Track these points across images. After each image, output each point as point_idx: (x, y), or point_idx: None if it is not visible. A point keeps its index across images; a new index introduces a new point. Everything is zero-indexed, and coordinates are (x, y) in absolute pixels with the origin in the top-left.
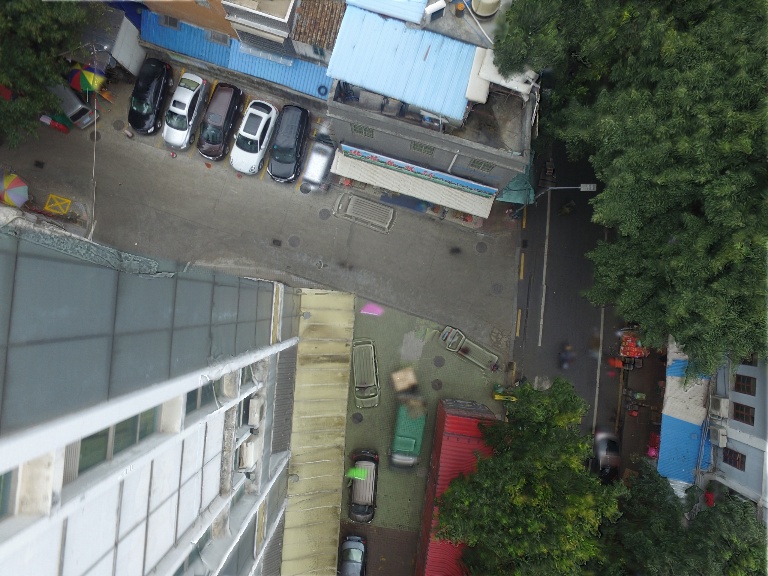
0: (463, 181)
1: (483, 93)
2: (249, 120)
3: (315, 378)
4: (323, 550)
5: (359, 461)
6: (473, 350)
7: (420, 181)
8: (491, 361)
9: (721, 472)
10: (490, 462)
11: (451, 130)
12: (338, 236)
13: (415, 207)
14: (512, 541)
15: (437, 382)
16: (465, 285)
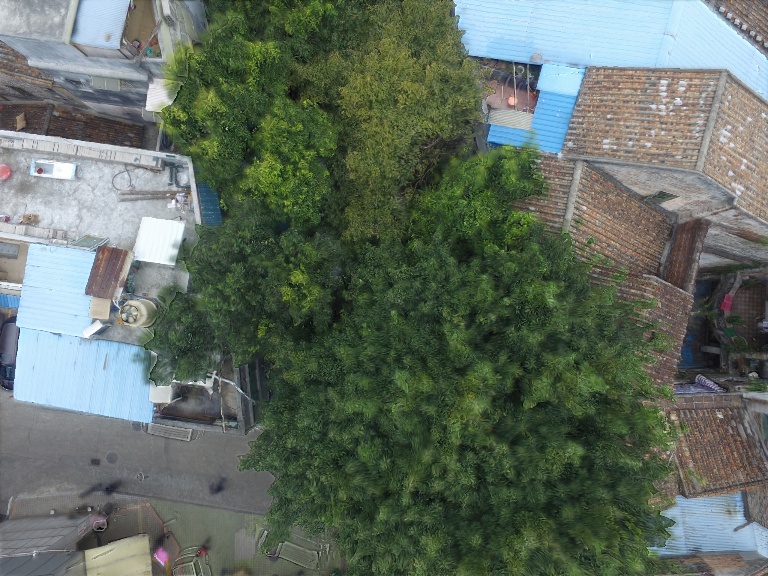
0: None
1: (166, 394)
2: None
3: None
4: None
5: None
6: (293, 552)
7: None
8: (313, 560)
9: None
10: None
11: None
12: (154, 445)
13: None
14: None
15: None
16: None
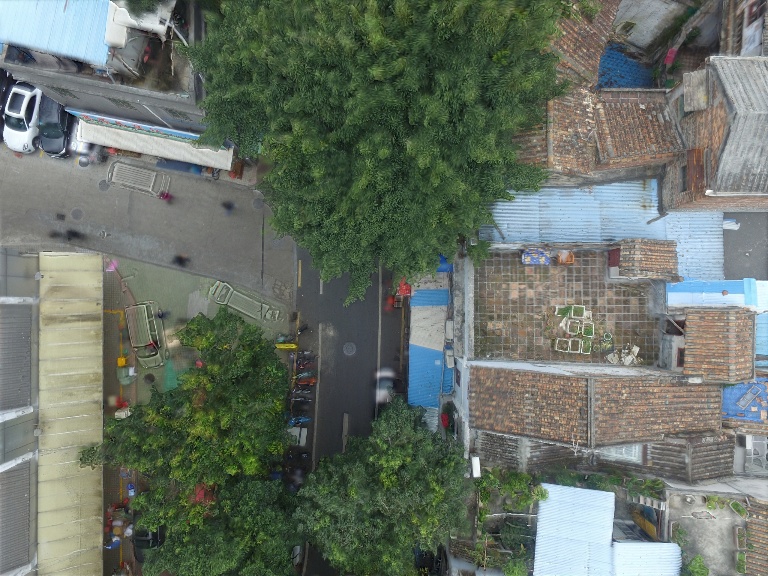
0: (183, 134)
1: (121, 38)
2: (12, 100)
3: (63, 337)
4: (87, 501)
5: None
6: (242, 301)
7: (162, 140)
8: (260, 310)
9: (455, 392)
10: None
11: (131, 81)
12: (119, 205)
13: (190, 170)
14: (145, 457)
15: None
16: (245, 241)
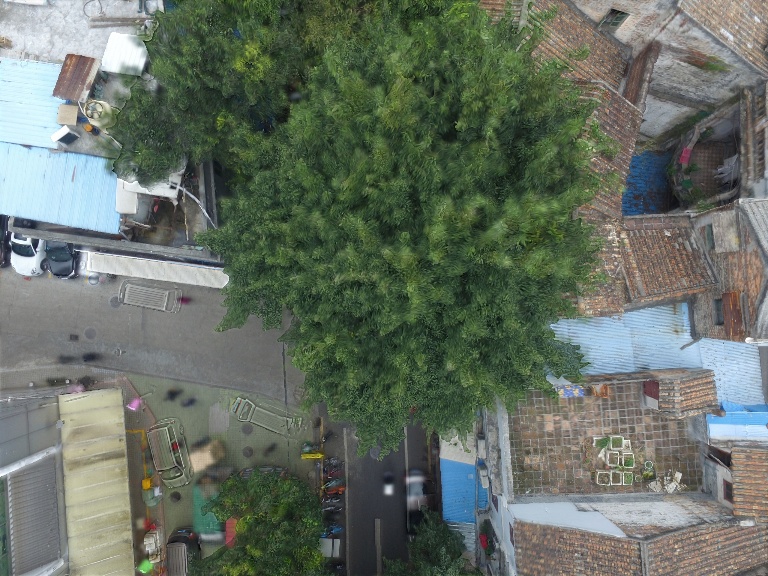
0: (196, 266)
1: (132, 204)
2: None
3: (88, 480)
4: None
5: (170, 543)
6: (265, 417)
7: (173, 266)
8: (284, 425)
9: (491, 511)
10: (189, 564)
11: (142, 232)
12: (132, 321)
13: None
14: None
15: (248, 449)
16: (262, 349)
